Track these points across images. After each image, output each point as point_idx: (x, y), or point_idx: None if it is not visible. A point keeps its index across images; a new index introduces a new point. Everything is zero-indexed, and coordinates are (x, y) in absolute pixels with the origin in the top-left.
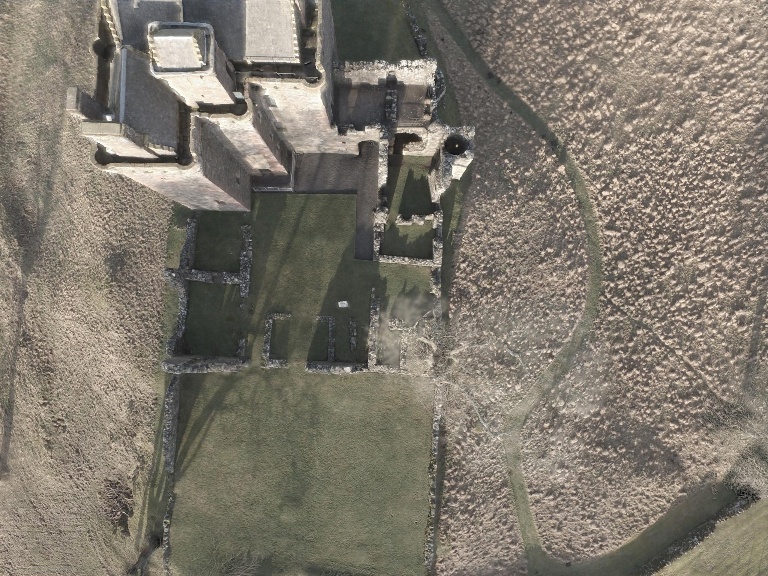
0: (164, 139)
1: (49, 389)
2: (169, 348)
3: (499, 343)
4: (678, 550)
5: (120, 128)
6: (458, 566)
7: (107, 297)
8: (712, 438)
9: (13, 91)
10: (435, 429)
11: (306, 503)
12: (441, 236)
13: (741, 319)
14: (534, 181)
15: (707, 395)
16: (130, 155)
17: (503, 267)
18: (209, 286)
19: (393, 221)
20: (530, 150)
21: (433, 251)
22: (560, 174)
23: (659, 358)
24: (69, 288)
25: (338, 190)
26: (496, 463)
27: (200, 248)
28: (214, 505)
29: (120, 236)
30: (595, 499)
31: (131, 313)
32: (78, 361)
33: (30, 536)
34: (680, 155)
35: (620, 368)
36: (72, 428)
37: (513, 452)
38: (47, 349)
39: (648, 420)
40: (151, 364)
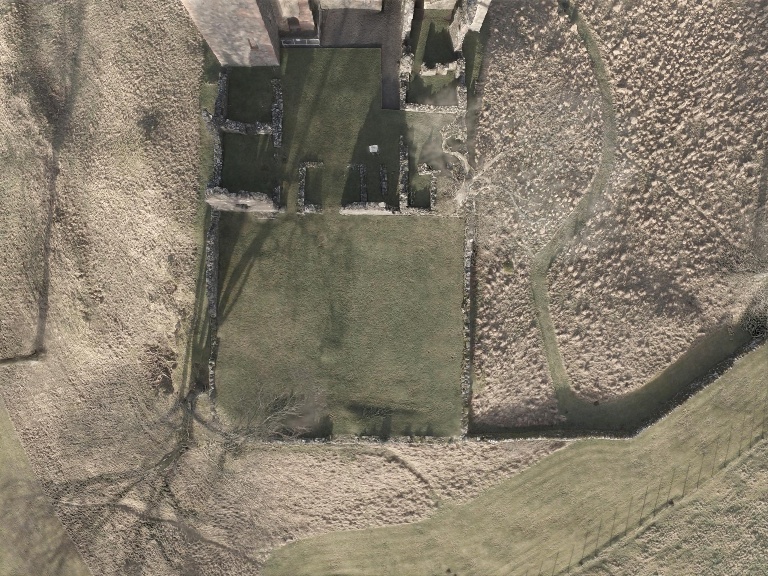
0: None
1: (85, 261)
2: None
3: (523, 190)
4: (700, 384)
5: None
6: (492, 403)
7: (142, 155)
8: (727, 281)
9: None
10: (467, 266)
11: (345, 344)
12: (464, 83)
13: (749, 171)
14: (549, 39)
15: (720, 242)
16: None
17: (523, 119)
18: (243, 138)
19: (417, 72)
20: (544, 10)
21: (458, 97)
22: (573, 34)
23: (674, 208)
24: (102, 157)
25: (363, 44)
26: (525, 304)
27: (232, 102)
28: (257, 348)
29: (152, 99)
30: (619, 339)
31: (167, 169)
32: (113, 229)
33: (70, 414)
34: (685, 17)
35: (637, 218)
36: (109, 298)
37: (540, 294)
38: (81, 223)
39: (666, 266)
40: (189, 215)
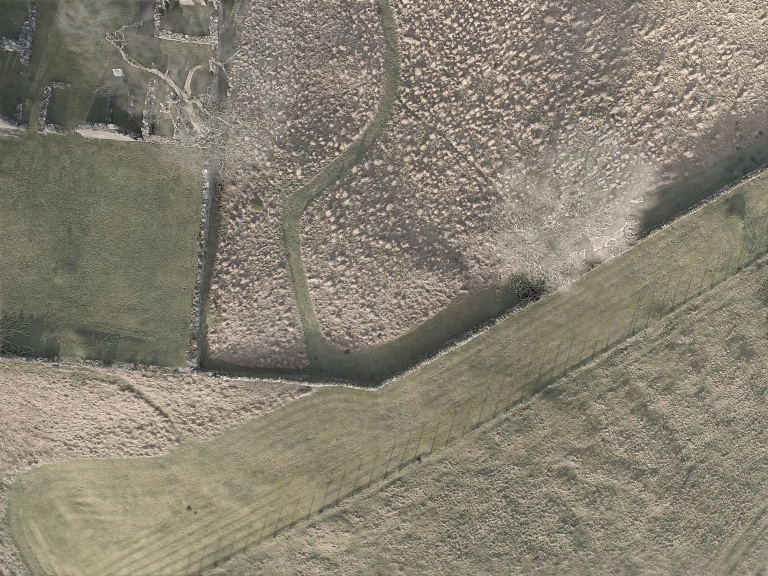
0: None
1: None
2: None
3: (282, 129)
4: (453, 341)
5: None
6: (232, 340)
7: None
8: (496, 240)
9: None
10: (204, 197)
11: (81, 268)
12: (220, 14)
13: (537, 133)
14: None
15: (496, 201)
16: None
17: (291, 58)
18: None
19: (177, 1)
20: None
21: None
22: None
23: (451, 163)
24: None
25: None
26: (273, 244)
27: None
28: None
29: None
30: (375, 289)
31: None
32: None
33: None
34: None
35: (411, 170)
36: None
37: (292, 236)
38: None
39: (435, 221)
40: None
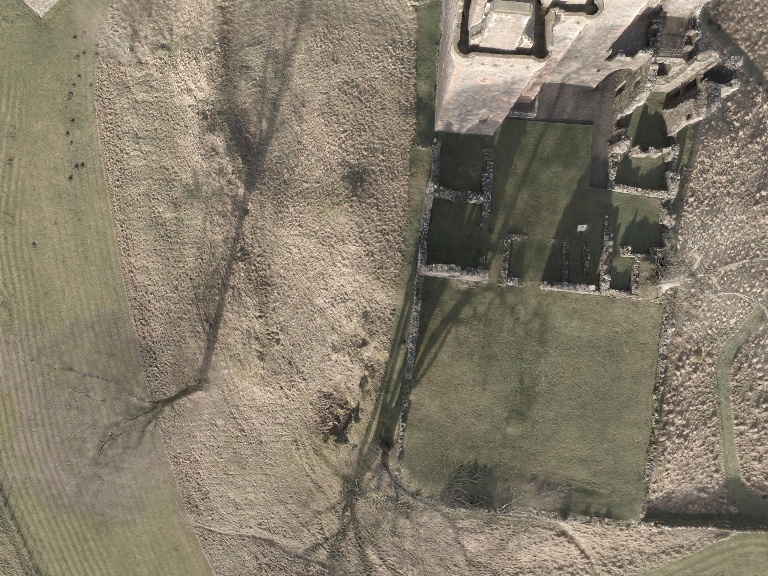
0: (528, 31)
1: (265, 302)
2: (422, 258)
3: None
4: None
5: (530, 7)
6: (667, 489)
7: (347, 211)
8: None
9: (239, 16)
10: (663, 353)
11: (531, 418)
12: (675, 169)
13: None
14: (752, 126)
15: None
16: (490, 46)
17: (722, 206)
18: (451, 204)
19: (626, 153)
20: (748, 96)
21: (668, 182)
22: None
23: None
24: (297, 205)
25: (575, 120)
26: (709, 393)
27: (443, 168)
28: (445, 413)
29: (358, 155)
30: None
31: (371, 227)
32: (300, 276)
33: (227, 446)
34: None
35: None
36: (286, 341)
37: (724, 384)
38: (265, 264)
39: None
40: (392, 276)
